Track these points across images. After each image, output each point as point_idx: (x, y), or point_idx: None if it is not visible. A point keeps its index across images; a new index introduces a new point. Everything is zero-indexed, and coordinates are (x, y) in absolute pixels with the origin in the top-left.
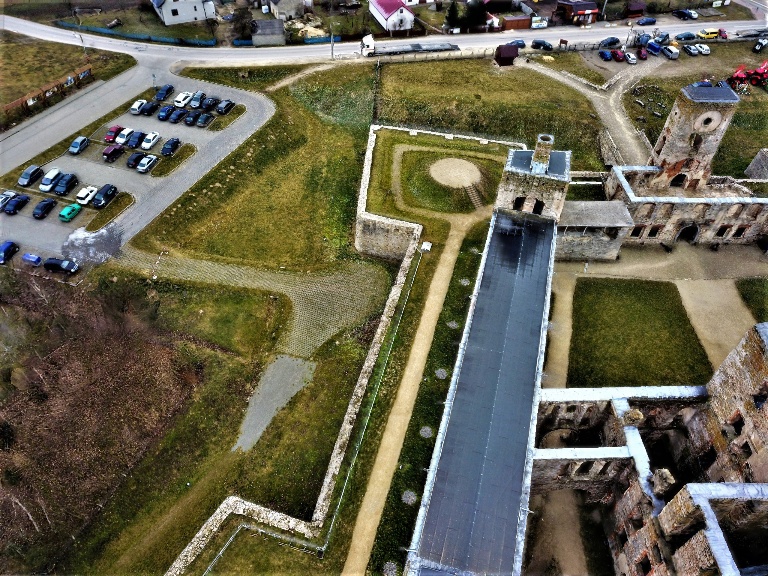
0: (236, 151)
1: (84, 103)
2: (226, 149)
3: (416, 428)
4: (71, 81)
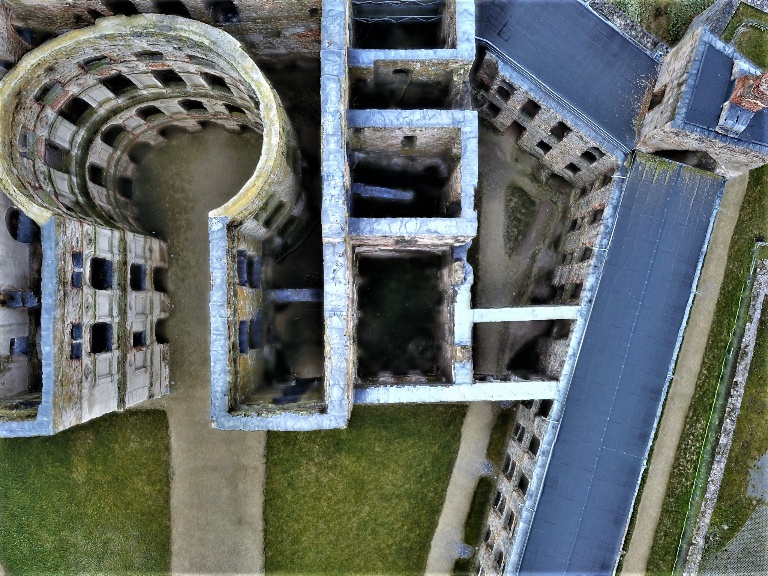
0: None
1: None
2: None
3: None
4: None
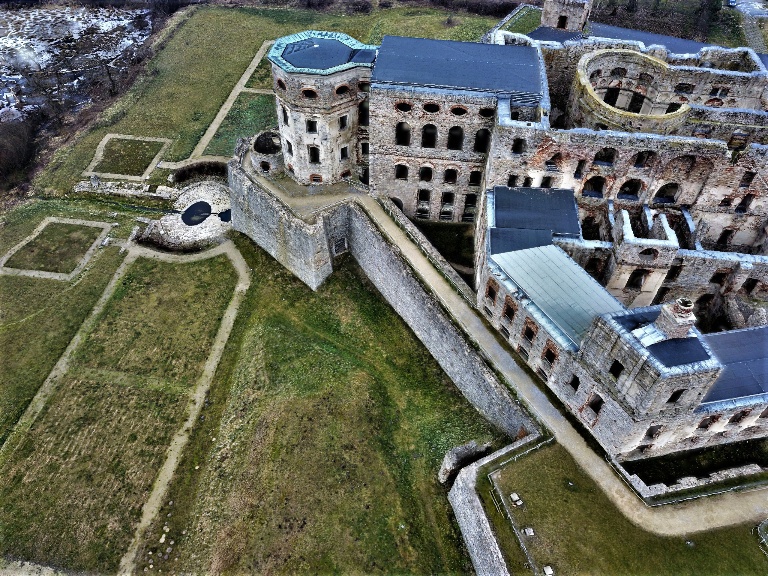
0: None
1: None
2: None
3: None
4: None
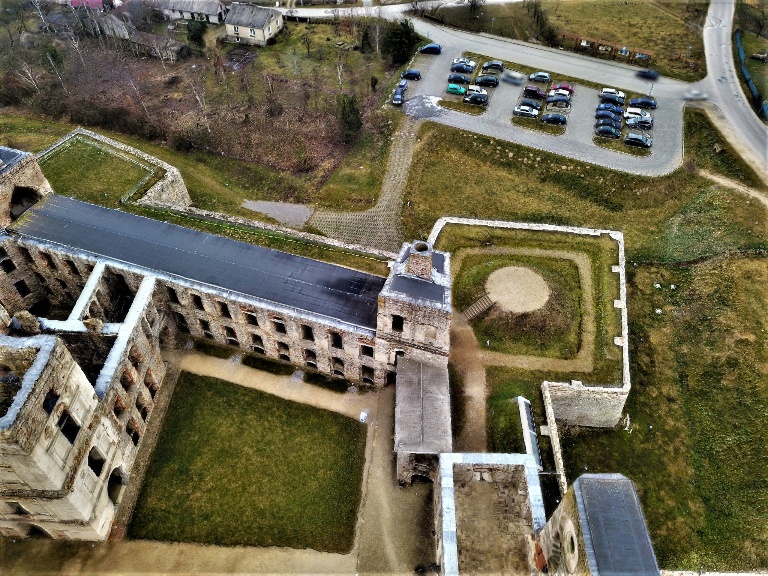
0: (564, 157)
1: (606, 70)
2: (565, 151)
3: None
4: (627, 53)
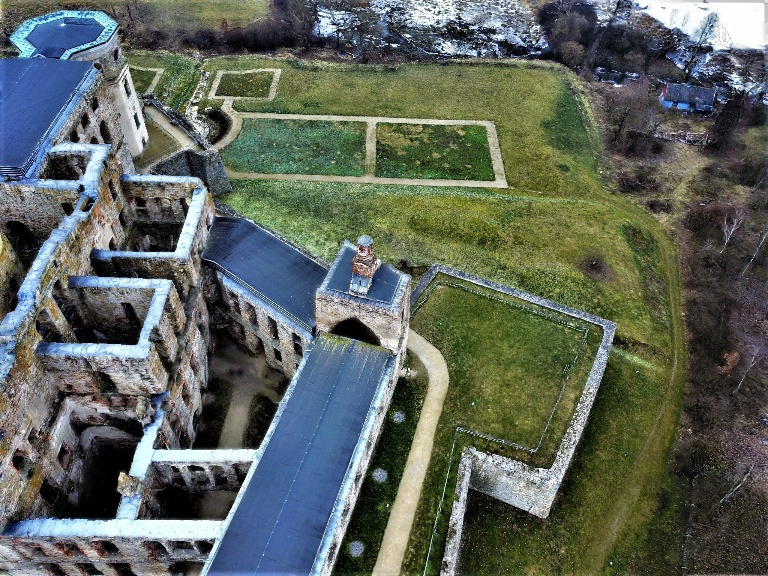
0: None
1: None
2: None
3: (368, 554)
4: None
